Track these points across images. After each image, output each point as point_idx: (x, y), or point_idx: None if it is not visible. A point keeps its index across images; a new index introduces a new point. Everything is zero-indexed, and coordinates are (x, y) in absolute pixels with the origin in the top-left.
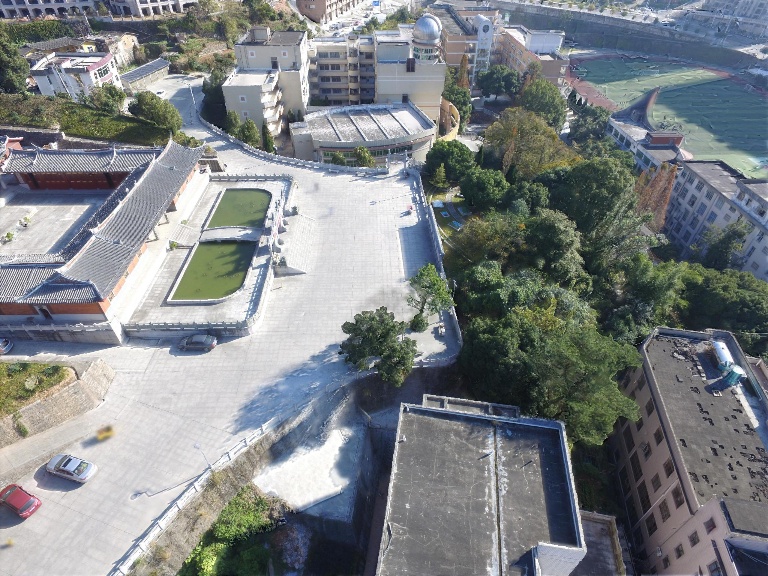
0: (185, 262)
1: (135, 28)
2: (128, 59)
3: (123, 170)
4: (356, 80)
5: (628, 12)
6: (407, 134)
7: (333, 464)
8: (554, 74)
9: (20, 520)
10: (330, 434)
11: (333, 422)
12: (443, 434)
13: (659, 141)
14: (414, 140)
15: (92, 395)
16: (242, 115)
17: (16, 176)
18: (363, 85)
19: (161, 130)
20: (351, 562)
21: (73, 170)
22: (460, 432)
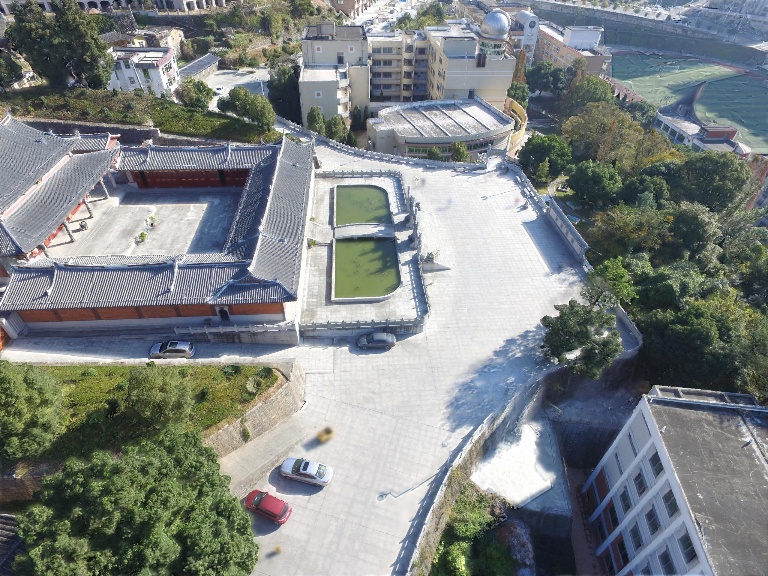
0: (329, 260)
1: (181, 23)
2: (176, 54)
3: (242, 167)
4: (409, 76)
5: (641, 9)
6: (487, 129)
7: (535, 459)
8: (596, 70)
9: (276, 526)
10: (522, 429)
11: (524, 417)
12: (696, 424)
13: (714, 135)
14: (496, 135)
15: (296, 397)
16: None
17: (126, 174)
18: (414, 81)
19: (255, 126)
20: (571, 556)
21: (190, 167)
22: (711, 421)
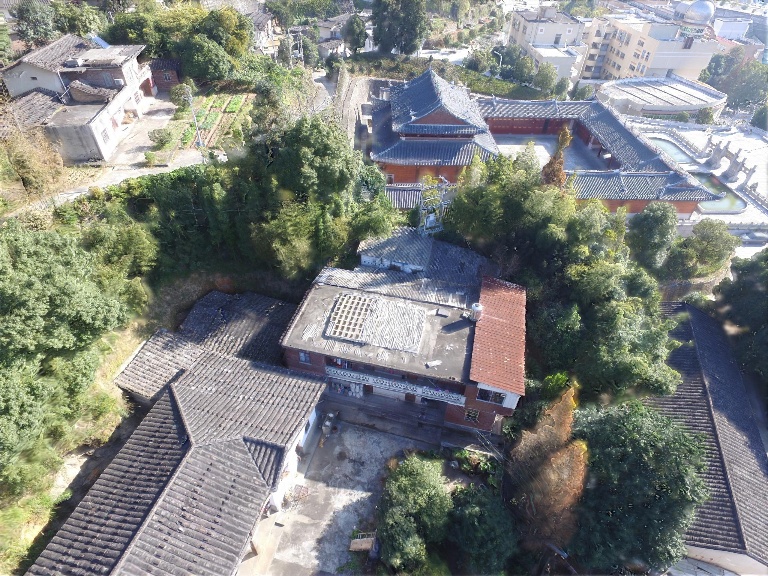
0: None
1: None
2: None
3: (571, 117)
4: (591, 58)
5: (749, 6)
6: (704, 101)
7: None
8: None
9: None
10: None
11: None
12: None
13: None
14: (715, 106)
15: None
16: None
17: None
18: None
19: None
20: None
21: (531, 116)
22: None
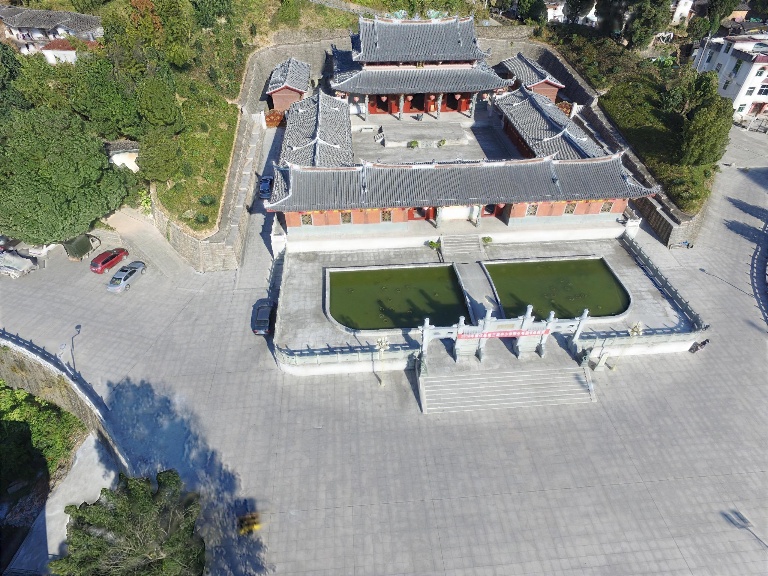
0: None
1: None
2: None
3: None
4: None
5: None
6: None
7: None
8: None
9: None
10: None
11: None
12: None
13: None
14: None
15: (202, 261)
16: None
17: None
18: None
19: (678, 151)
20: None
21: (518, 127)
22: None
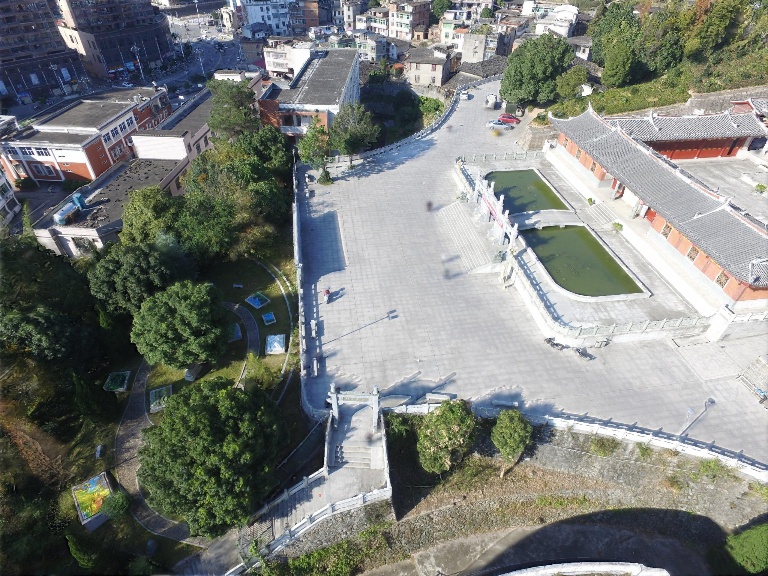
0: None
1: None
2: None
3: None
4: None
5: None
6: None
7: None
8: None
9: None
10: None
11: None
12: None
13: None
14: None
15: None
16: None
17: None
18: None
19: None
20: None
21: None
22: None
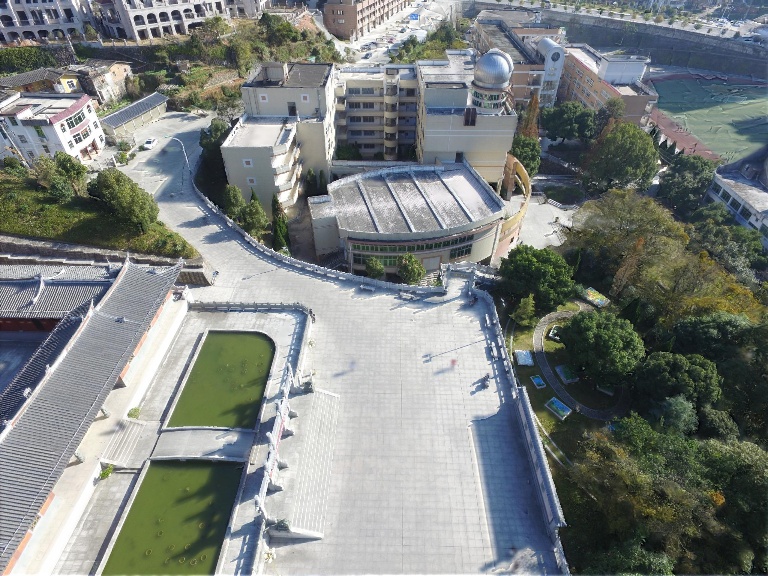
0: (121, 512)
1: (129, 55)
2: (118, 93)
3: (50, 316)
4: (393, 122)
5: (703, 24)
6: (466, 217)
7: None
8: (637, 112)
9: None
10: None
11: None
12: None
13: None
14: (477, 228)
15: None
16: (247, 182)
17: None
18: (401, 127)
19: (128, 224)
20: None
21: None
22: None
